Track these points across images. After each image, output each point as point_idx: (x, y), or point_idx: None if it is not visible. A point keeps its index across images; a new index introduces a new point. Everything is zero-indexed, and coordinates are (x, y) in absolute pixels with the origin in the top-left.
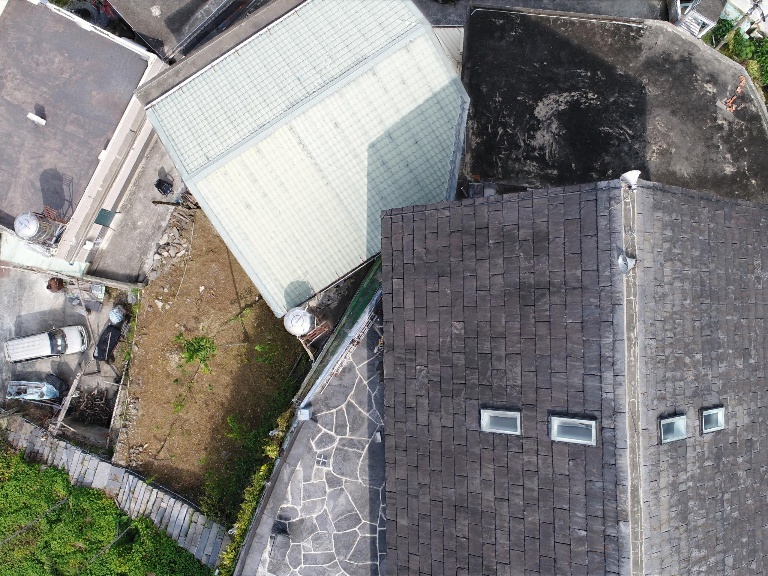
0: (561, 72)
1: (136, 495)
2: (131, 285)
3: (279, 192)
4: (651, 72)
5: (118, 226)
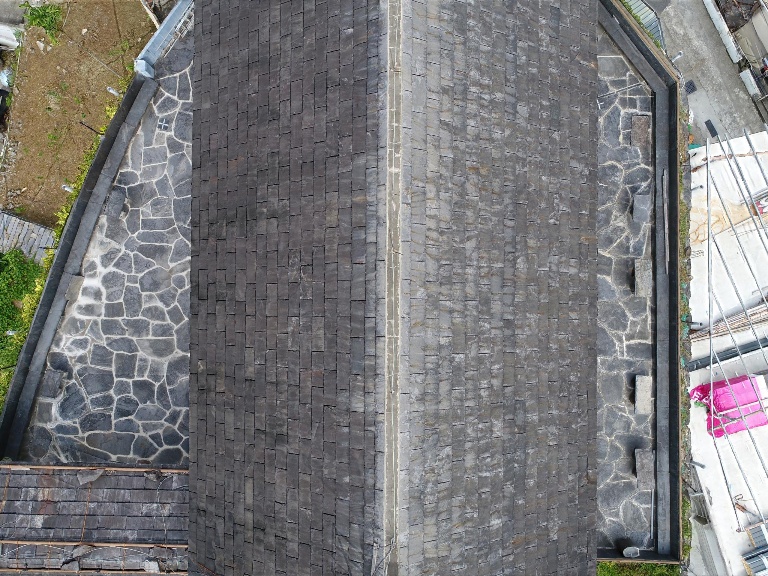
0: None
1: (9, 231)
2: (12, 25)
3: None
4: None
5: None
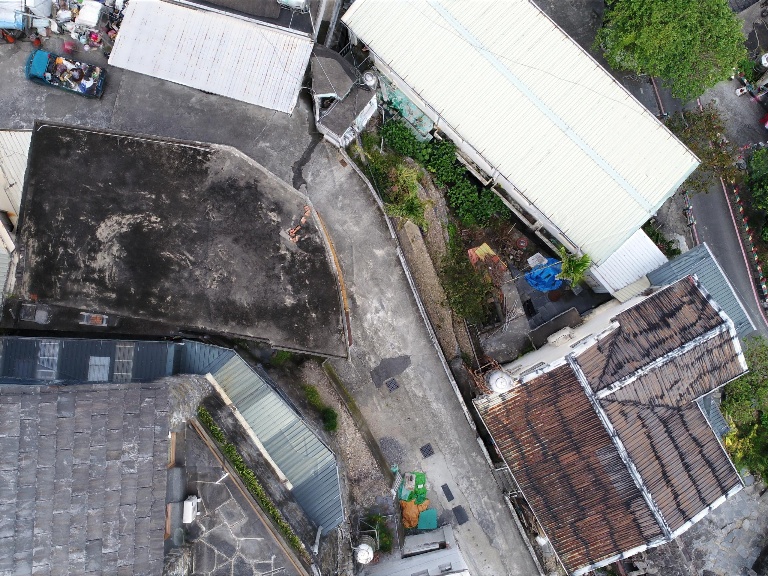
0: (125, 193)
1: None
2: None
3: None
4: (216, 198)
5: None
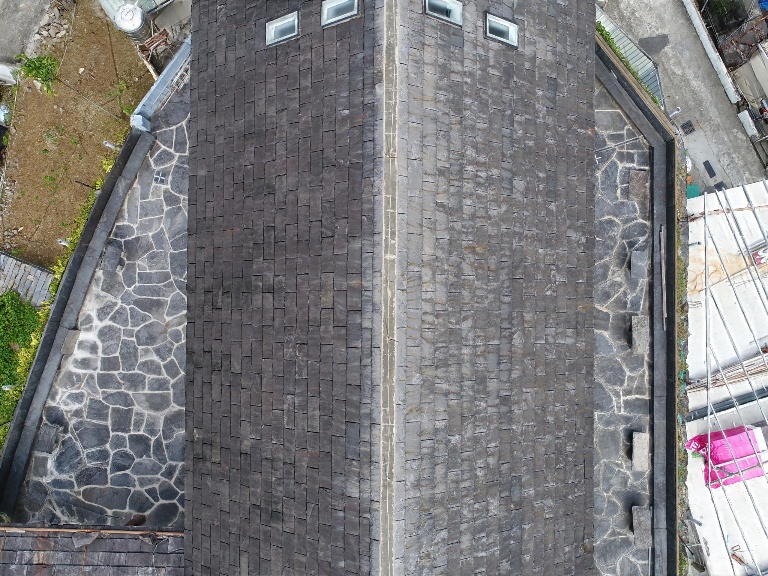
0: None
1: (6, 272)
2: (9, 64)
3: None
4: None
5: None
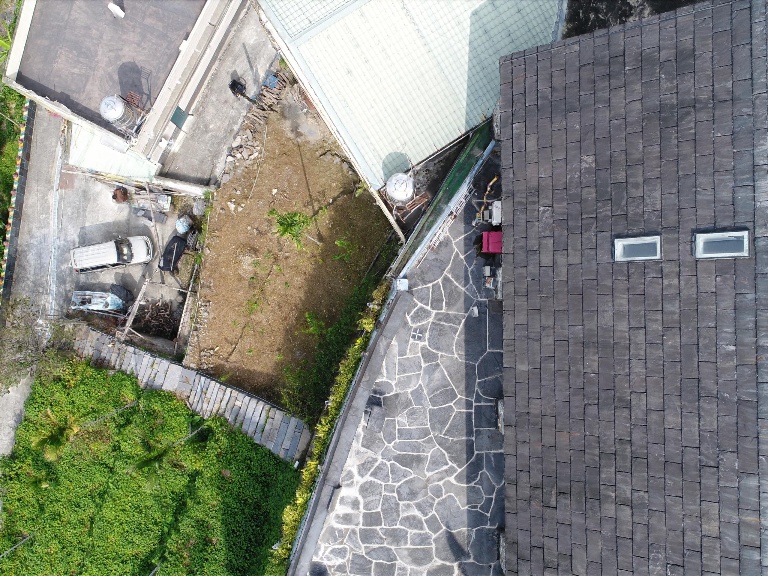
0: None
1: (209, 395)
2: (204, 187)
3: (381, 58)
4: None
5: (190, 129)
